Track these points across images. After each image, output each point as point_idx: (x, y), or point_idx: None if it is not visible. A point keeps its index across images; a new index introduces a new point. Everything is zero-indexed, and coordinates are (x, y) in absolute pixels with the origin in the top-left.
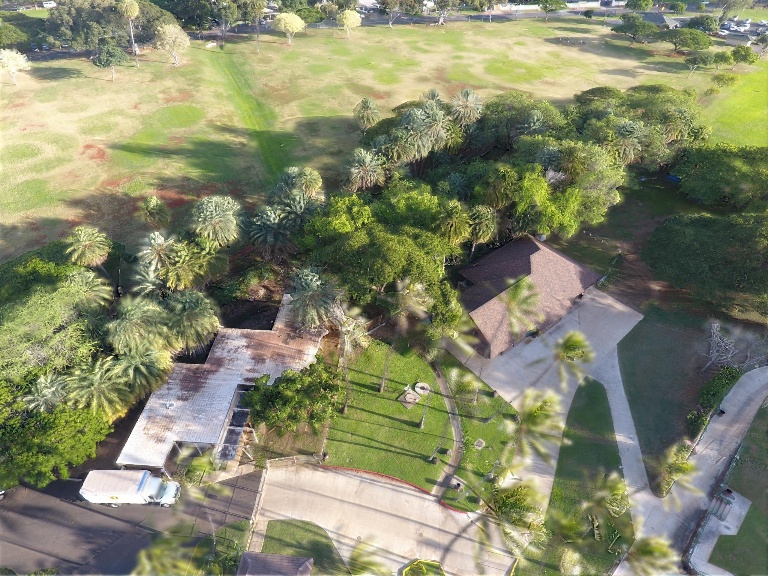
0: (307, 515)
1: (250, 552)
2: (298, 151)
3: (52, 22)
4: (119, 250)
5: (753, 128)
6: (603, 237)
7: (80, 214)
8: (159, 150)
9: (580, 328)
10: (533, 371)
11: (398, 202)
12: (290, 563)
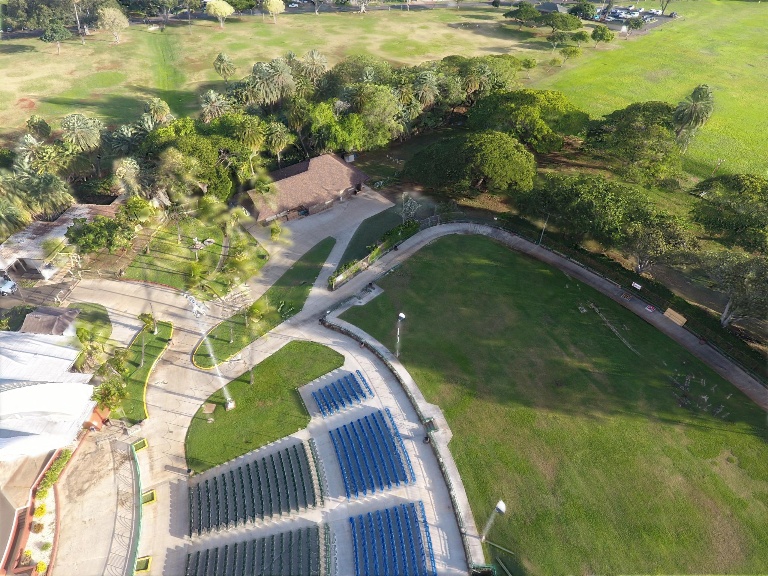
0: (97, 301)
1: (43, 306)
2: (191, 104)
3: (13, 7)
4: (14, 156)
5: (578, 90)
6: (400, 160)
7: (1, 143)
8: (79, 103)
9: (344, 211)
10: (294, 234)
11: (214, 119)
12: (65, 309)
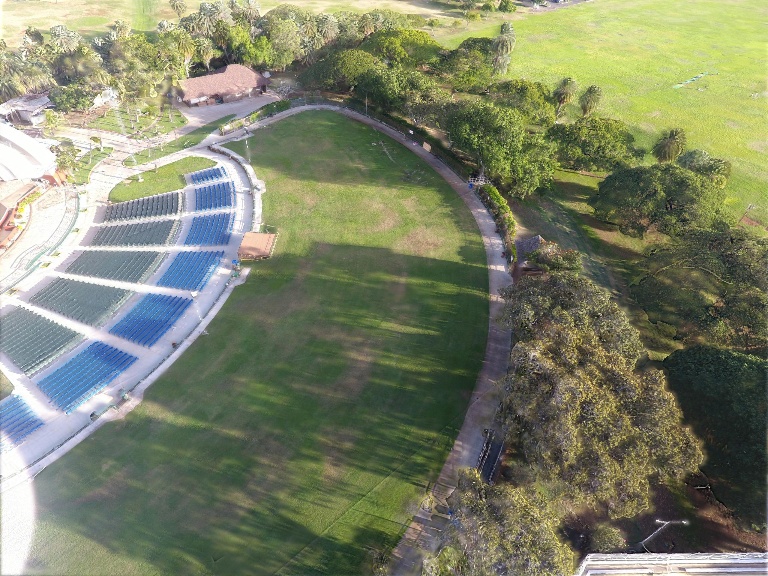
0: (66, 136)
1: None
2: None
3: None
4: None
5: None
6: None
7: None
8: None
9: (250, 102)
10: (209, 112)
11: (160, 34)
12: None
